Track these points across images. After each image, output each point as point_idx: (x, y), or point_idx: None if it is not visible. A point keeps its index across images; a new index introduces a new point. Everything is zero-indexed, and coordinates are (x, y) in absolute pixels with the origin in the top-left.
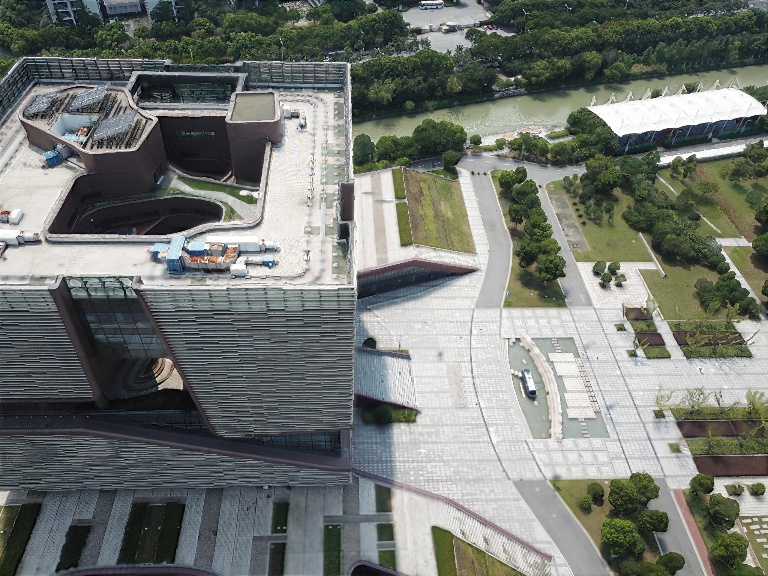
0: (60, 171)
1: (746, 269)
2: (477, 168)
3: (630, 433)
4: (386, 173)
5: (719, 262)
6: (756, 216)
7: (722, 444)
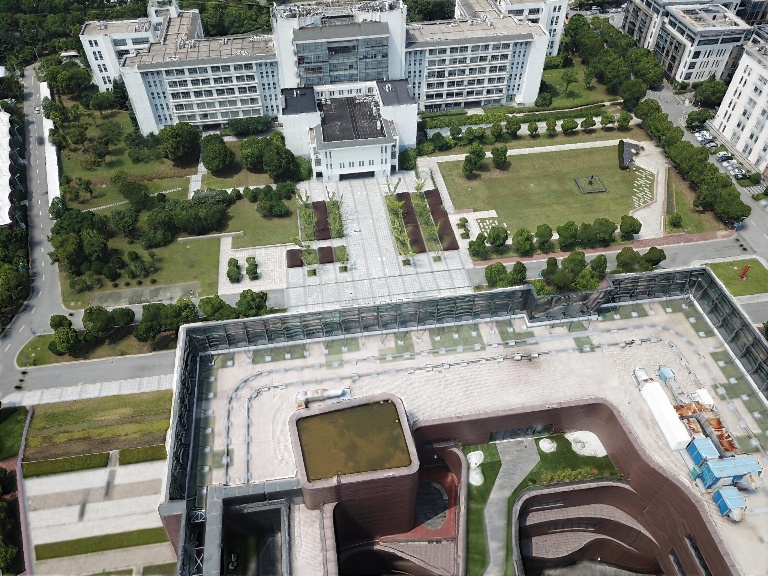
0: None
1: (233, 183)
2: (5, 383)
3: (430, 282)
4: (31, 487)
5: (230, 194)
6: (174, 158)
7: (428, 233)
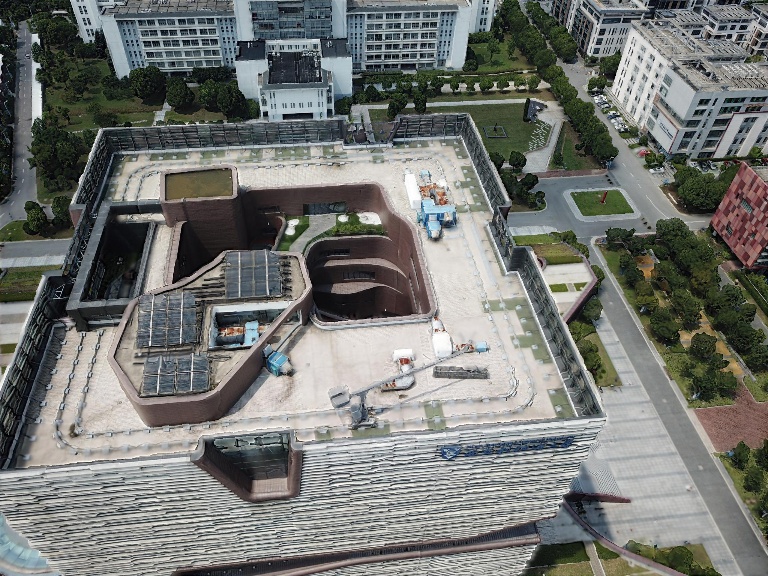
0: (298, 354)
1: (192, 118)
2: None
3: None
4: (0, 309)
5: None
6: (142, 95)
7: None
